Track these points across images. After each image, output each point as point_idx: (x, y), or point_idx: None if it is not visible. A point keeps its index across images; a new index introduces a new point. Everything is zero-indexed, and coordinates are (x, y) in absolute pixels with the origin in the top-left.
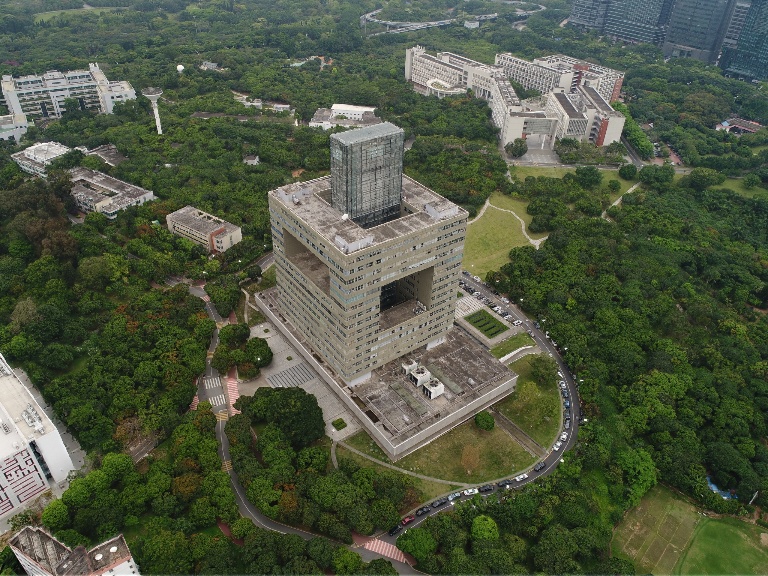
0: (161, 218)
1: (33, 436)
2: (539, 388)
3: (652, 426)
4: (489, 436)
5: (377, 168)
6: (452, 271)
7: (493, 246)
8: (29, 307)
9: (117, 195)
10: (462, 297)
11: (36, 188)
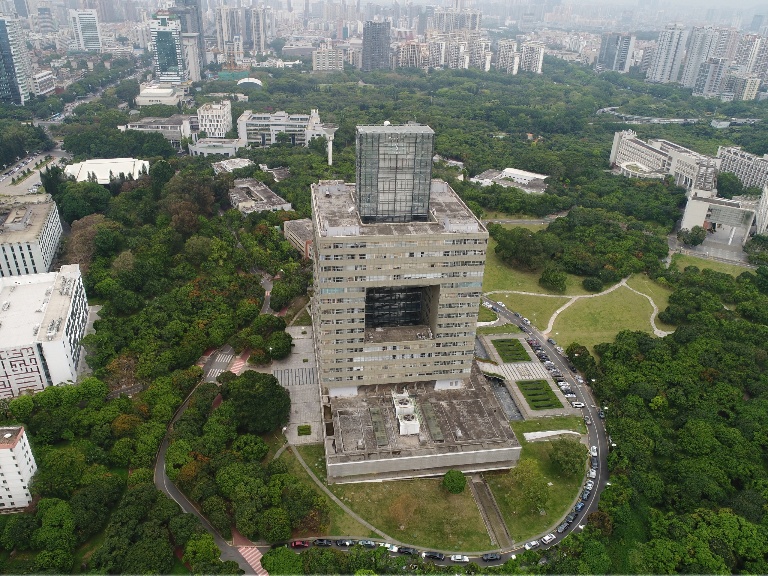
0: (282, 224)
1: (43, 339)
2: (556, 478)
3: (682, 574)
4: (454, 502)
5: (398, 167)
6: (467, 300)
7: (602, 324)
8: (127, 258)
9: (262, 201)
10: (529, 362)
11: (198, 180)
